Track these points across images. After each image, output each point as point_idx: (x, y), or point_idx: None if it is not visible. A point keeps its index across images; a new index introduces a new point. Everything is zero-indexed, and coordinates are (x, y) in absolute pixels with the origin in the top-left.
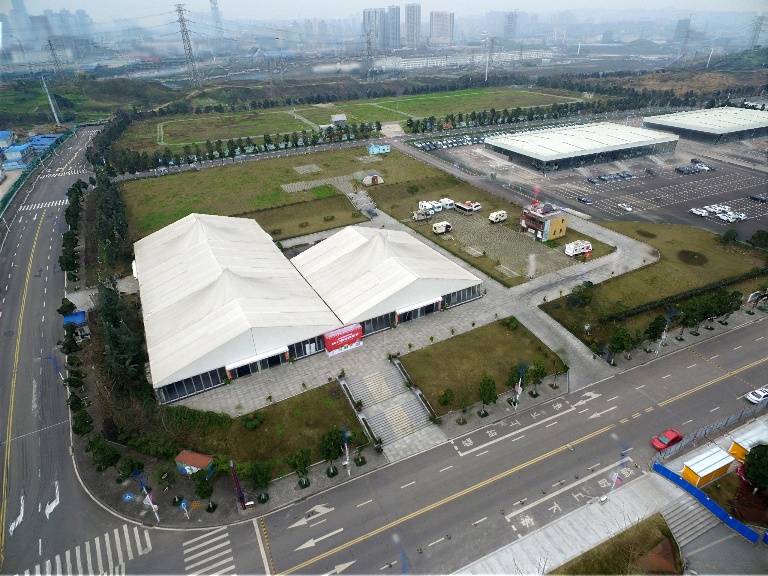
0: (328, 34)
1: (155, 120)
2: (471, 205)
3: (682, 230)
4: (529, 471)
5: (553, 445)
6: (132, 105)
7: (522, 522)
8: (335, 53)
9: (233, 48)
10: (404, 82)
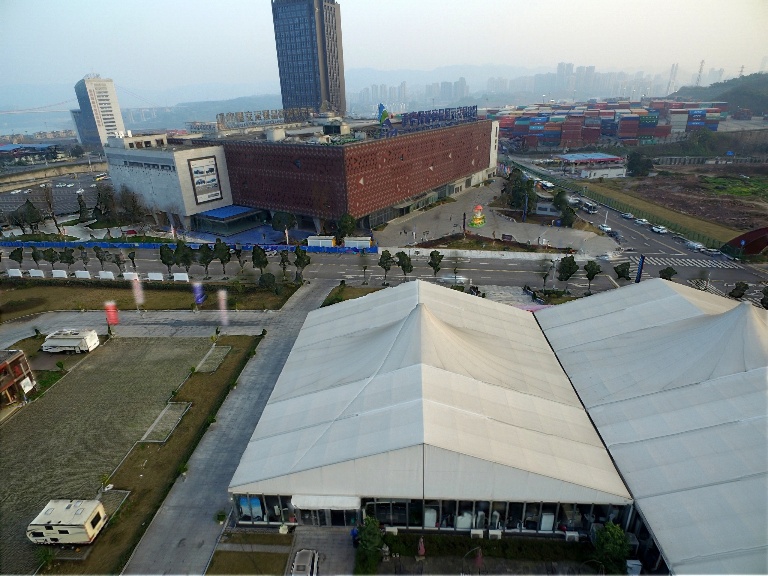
0: None
1: None
2: None
3: None
4: None
5: None
6: None
7: (463, 259)
8: None
9: None
10: None
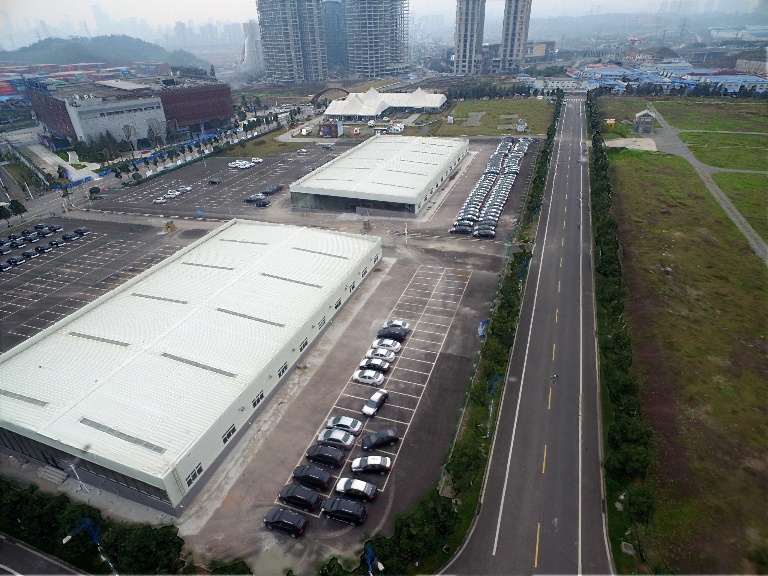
0: None
1: None
2: None
3: None
4: (285, 118)
5: None
6: None
7: None
8: None
9: None
10: None
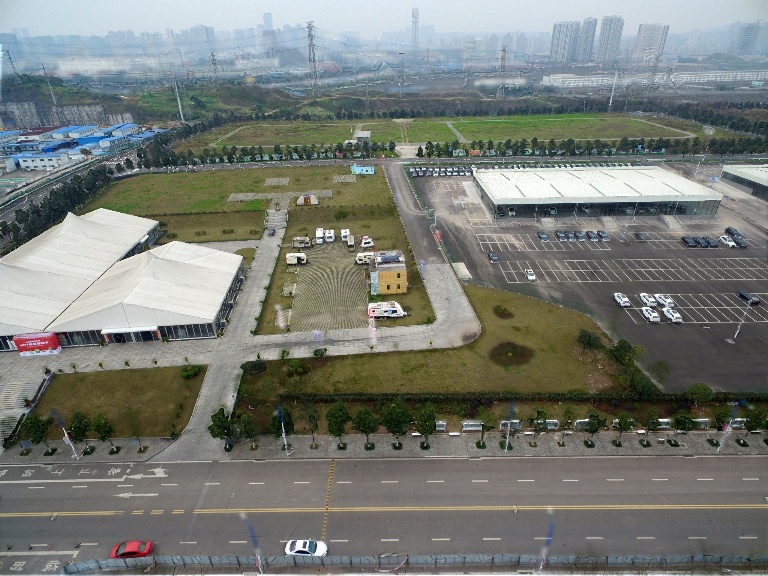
0: (456, 49)
1: (245, 123)
2: (362, 241)
3: (563, 317)
4: None
5: (46, 507)
6: (249, 109)
7: None
8: (463, 68)
9: (359, 61)
10: (532, 101)
